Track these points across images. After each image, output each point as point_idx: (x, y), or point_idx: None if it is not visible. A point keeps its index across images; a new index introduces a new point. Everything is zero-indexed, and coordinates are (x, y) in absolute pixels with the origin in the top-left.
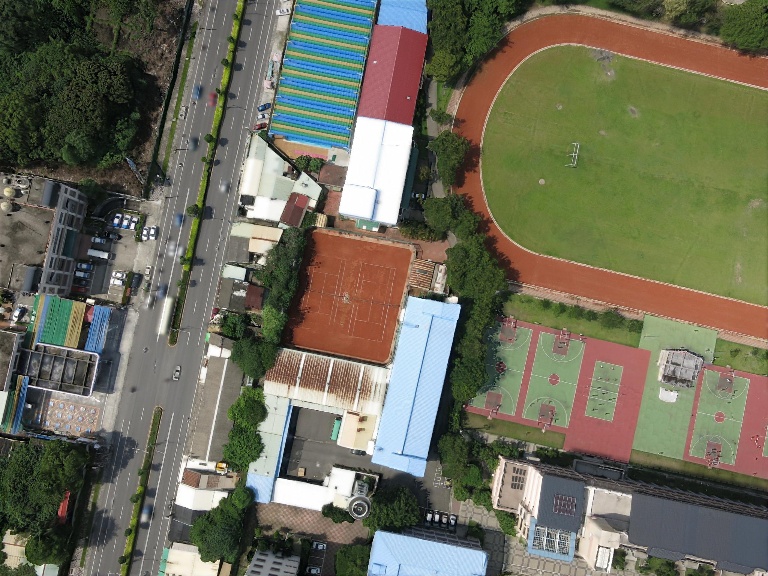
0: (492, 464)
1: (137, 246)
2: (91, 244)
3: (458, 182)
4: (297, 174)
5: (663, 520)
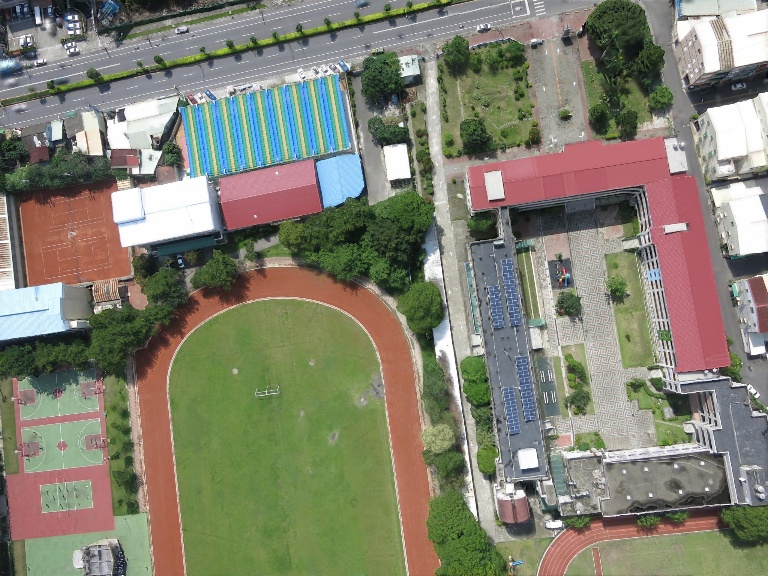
0: None
1: (59, 44)
2: (47, 7)
3: (208, 293)
4: (158, 147)
5: None
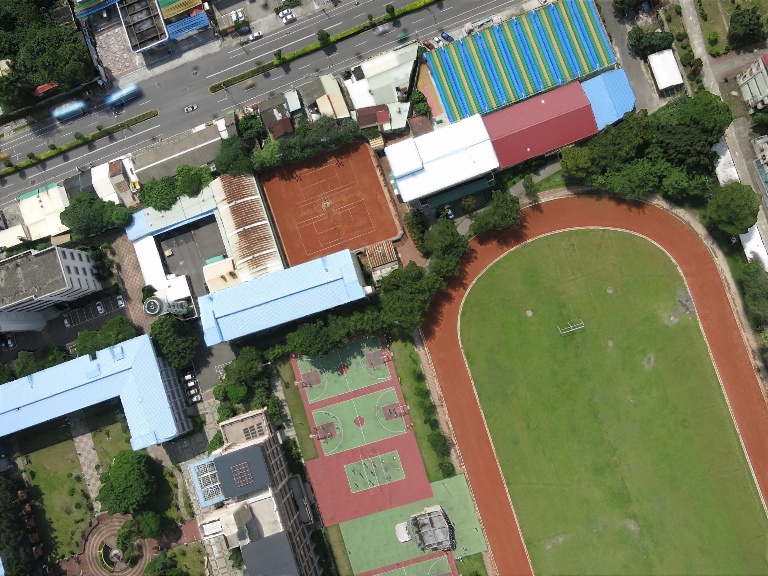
0: (255, 404)
1: (272, 13)
2: None
3: (483, 239)
4: (405, 99)
5: (276, 569)
